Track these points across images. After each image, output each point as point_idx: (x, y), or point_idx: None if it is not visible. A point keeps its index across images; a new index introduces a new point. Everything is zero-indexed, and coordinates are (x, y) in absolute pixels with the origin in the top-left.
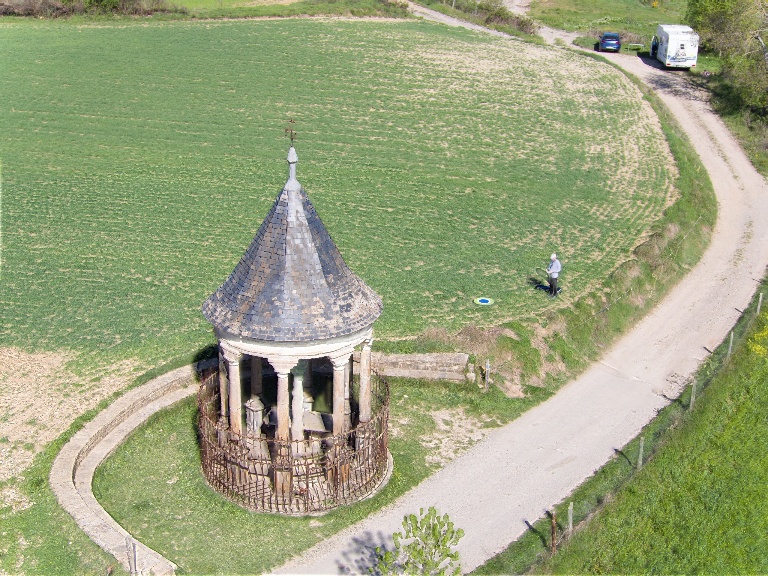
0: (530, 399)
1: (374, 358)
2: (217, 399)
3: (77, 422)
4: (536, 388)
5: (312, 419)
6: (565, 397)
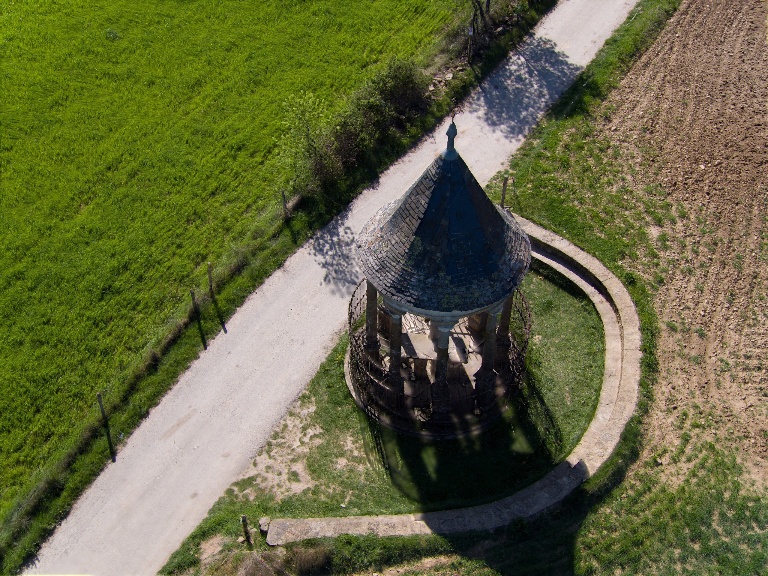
0: (193, 544)
1: (387, 521)
2: (553, 463)
3: (648, 348)
4: (183, 560)
5: (424, 346)
6: (147, 569)
